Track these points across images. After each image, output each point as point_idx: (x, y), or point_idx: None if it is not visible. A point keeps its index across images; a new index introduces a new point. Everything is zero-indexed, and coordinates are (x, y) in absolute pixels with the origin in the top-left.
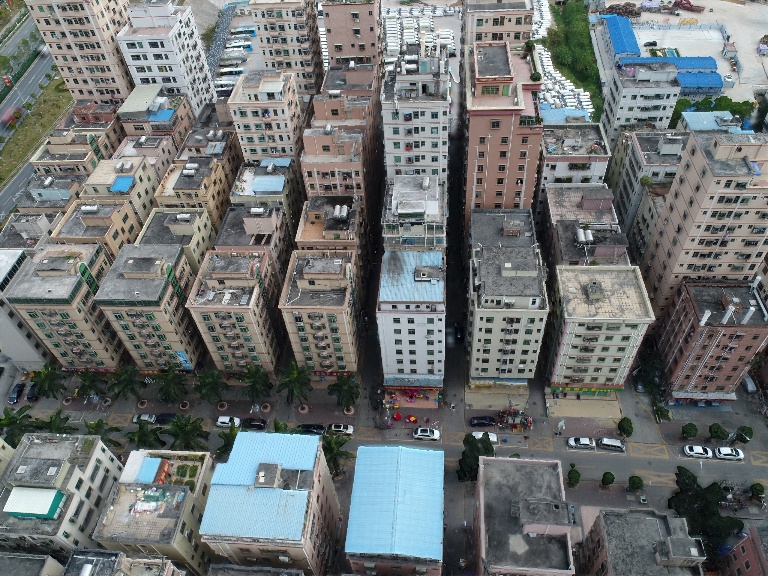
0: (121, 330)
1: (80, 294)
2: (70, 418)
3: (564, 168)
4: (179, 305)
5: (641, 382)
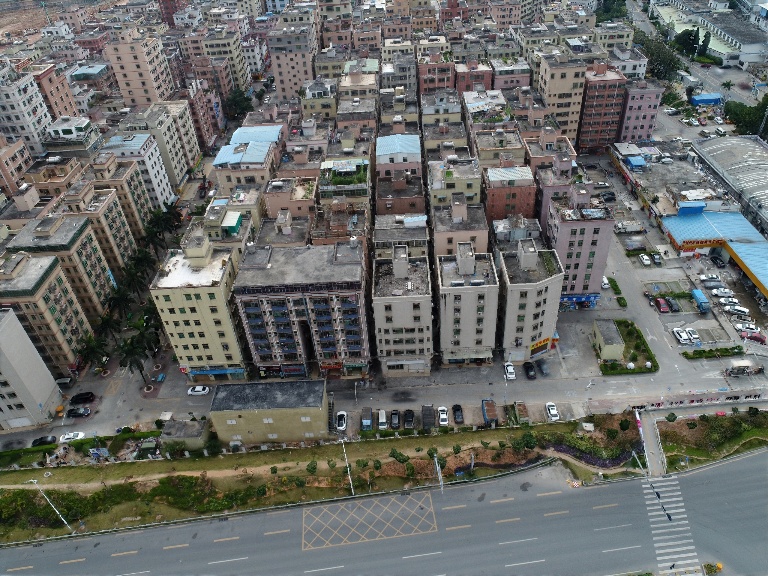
0: (83, 273)
1: None
2: None
3: None
4: None
5: None
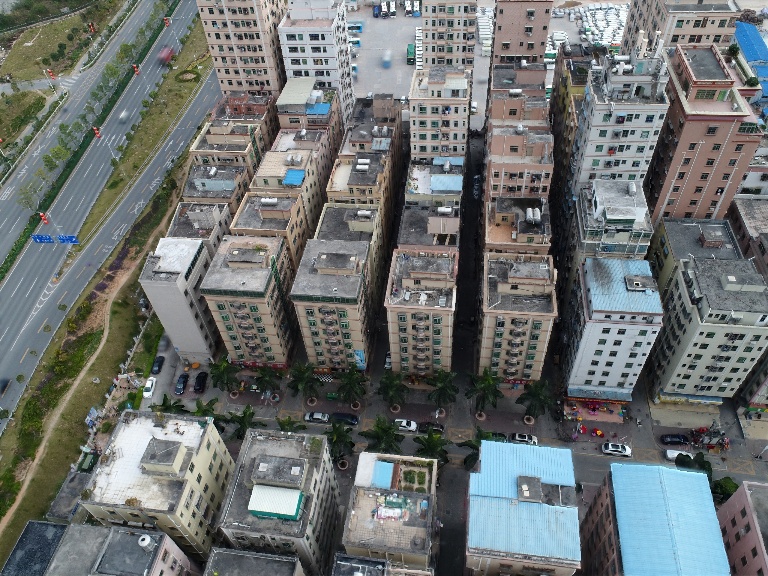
0: (306, 326)
1: (270, 288)
2: (239, 412)
3: (755, 178)
4: (364, 303)
5: None
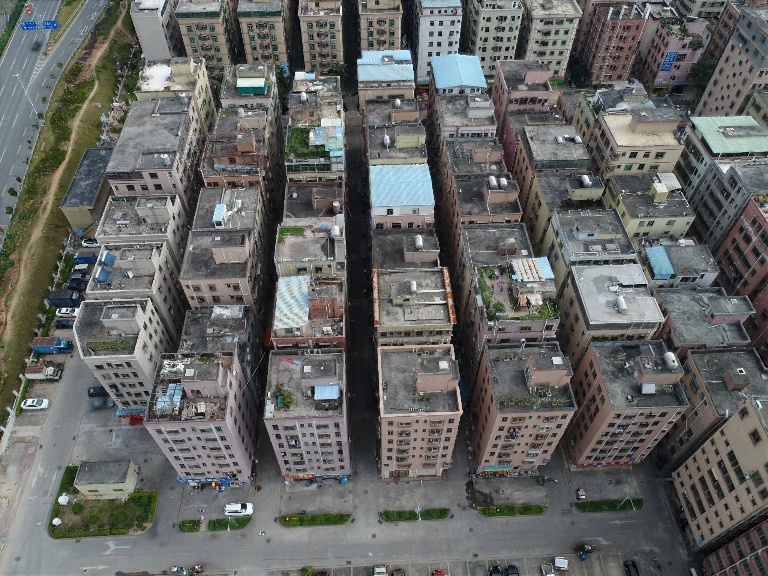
0: (248, 43)
1: None
2: None
3: None
4: (284, 28)
5: (574, 80)
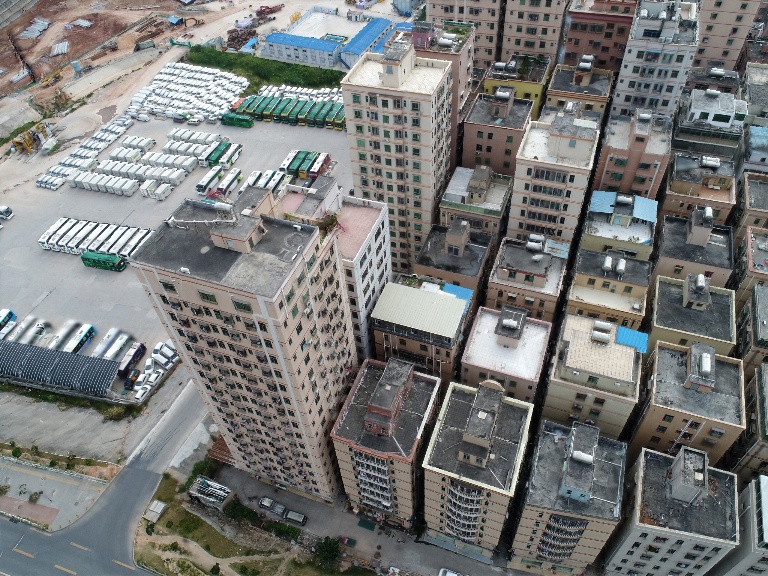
0: None
1: None
2: None
3: None
4: None
5: None
